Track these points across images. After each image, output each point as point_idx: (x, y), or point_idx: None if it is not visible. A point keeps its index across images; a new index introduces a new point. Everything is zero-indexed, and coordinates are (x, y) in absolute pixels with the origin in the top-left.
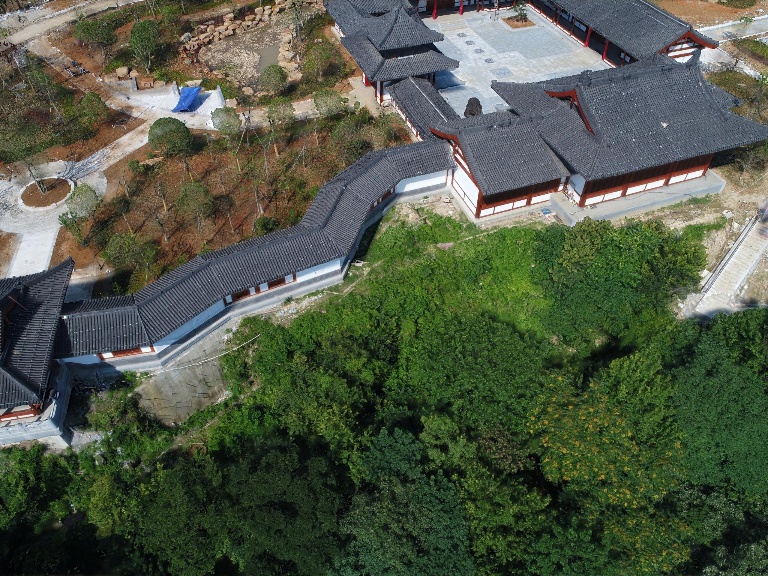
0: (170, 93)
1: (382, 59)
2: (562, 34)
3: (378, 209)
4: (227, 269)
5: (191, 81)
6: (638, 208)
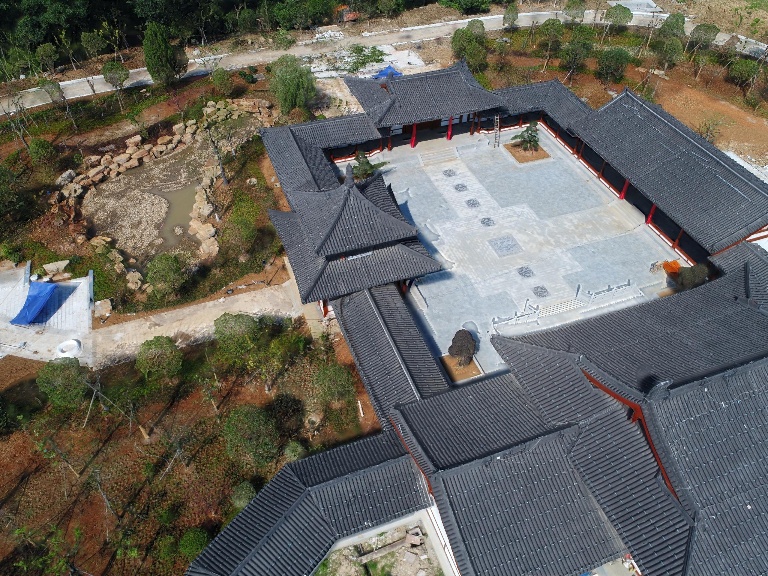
0: (18, 283)
1: (323, 263)
2: (587, 174)
3: None
4: None
5: (51, 264)
6: None
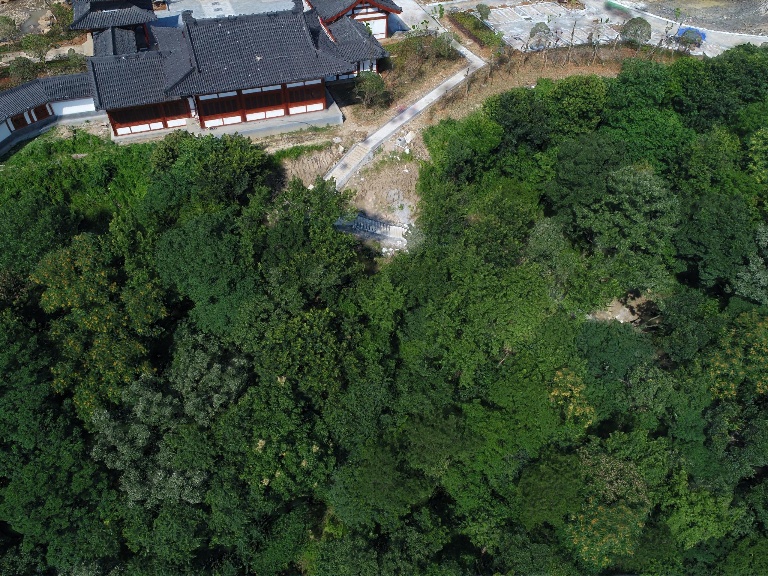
0: None
1: (86, 11)
2: (304, 5)
3: (33, 127)
4: None
5: None
6: (255, 131)
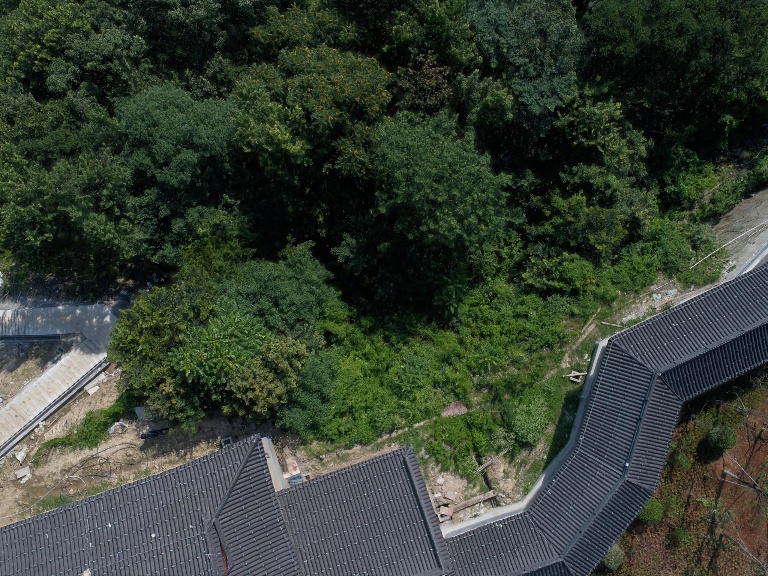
0: None
1: None
2: None
3: None
4: None
5: None
6: None
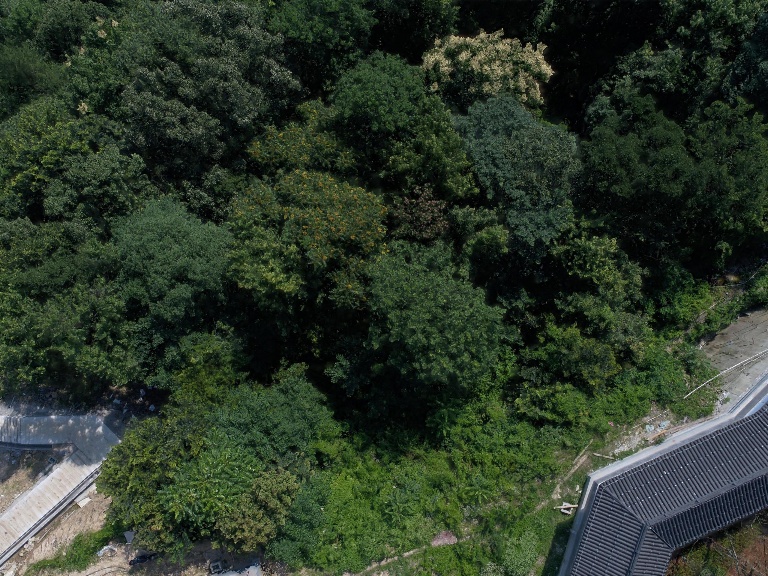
0: None
1: None
2: None
3: None
4: (767, 451)
5: None
6: None
